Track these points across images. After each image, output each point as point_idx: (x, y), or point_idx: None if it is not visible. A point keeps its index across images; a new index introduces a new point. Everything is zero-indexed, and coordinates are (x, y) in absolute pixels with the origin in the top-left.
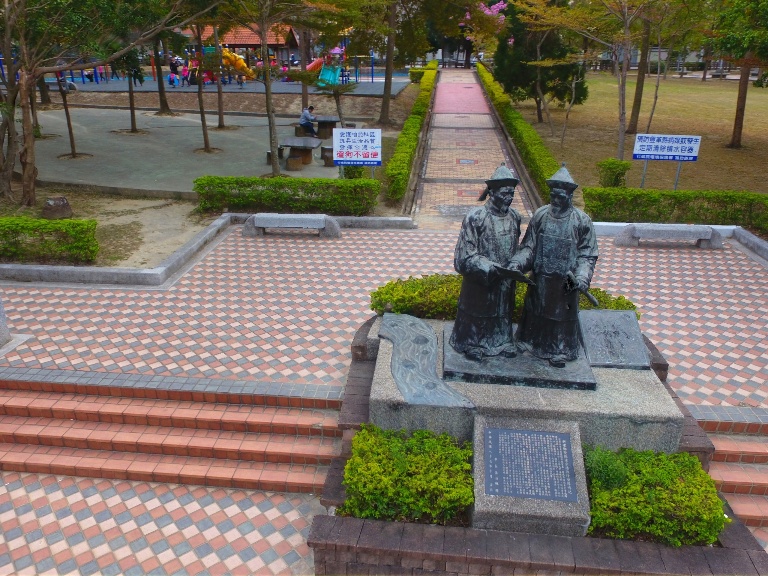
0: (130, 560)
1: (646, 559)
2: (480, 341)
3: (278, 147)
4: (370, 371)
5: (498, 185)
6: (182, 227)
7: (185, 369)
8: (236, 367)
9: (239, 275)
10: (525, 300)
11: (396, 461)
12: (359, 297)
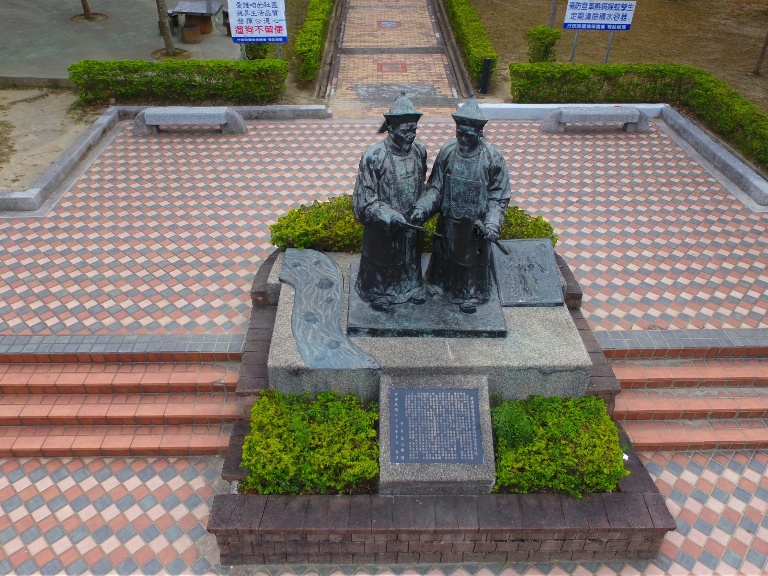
0: (22, 554)
1: (548, 513)
2: (386, 289)
3: (170, 14)
4: (272, 319)
5: (397, 121)
6: (61, 127)
7: (67, 324)
8: (126, 317)
9: (129, 191)
10: (434, 242)
11: (297, 434)
12: (265, 215)
